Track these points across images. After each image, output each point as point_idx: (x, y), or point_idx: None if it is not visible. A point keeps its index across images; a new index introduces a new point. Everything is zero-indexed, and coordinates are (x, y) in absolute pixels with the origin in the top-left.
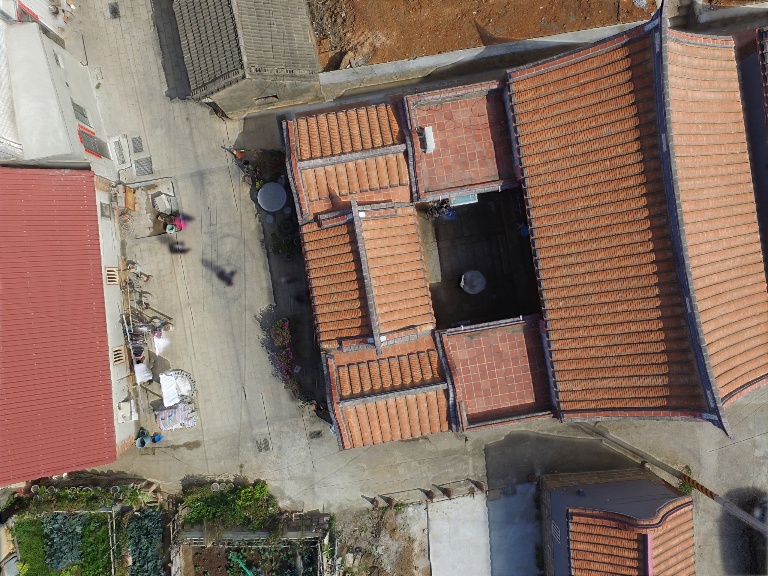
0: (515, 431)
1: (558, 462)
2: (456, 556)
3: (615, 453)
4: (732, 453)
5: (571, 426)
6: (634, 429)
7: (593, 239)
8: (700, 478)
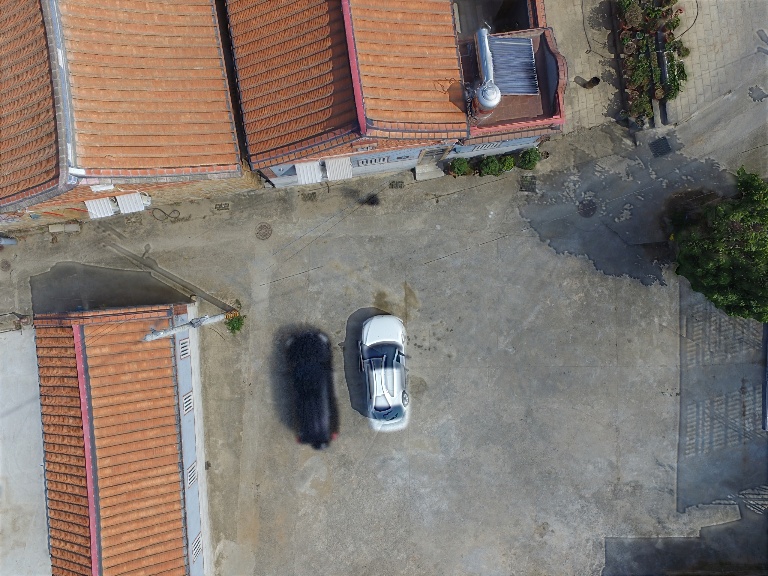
0: (61, 262)
1: (106, 295)
2: (4, 394)
3: (164, 286)
4: (285, 287)
5: (118, 257)
6: (183, 261)
7: (4, 7)
8: (250, 312)
